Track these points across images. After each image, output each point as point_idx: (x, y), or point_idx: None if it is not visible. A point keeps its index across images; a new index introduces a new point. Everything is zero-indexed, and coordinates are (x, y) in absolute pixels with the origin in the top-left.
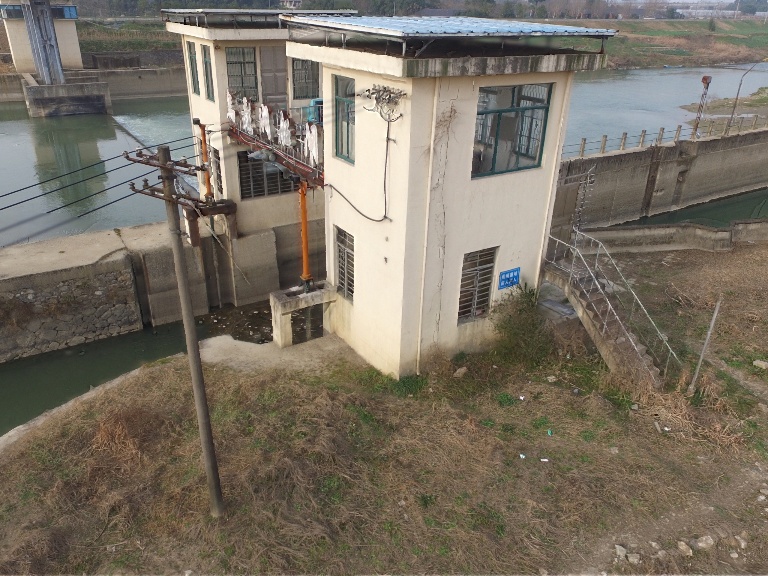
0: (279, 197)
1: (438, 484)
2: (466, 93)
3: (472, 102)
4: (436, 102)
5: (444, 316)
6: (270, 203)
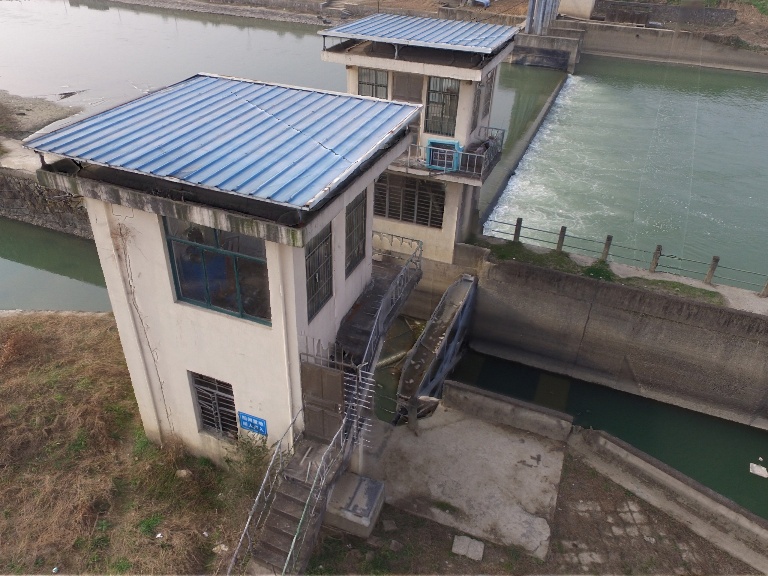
0: (397, 224)
1: None
2: (143, 215)
3: (153, 226)
4: (105, 214)
5: (180, 414)
6: (388, 226)
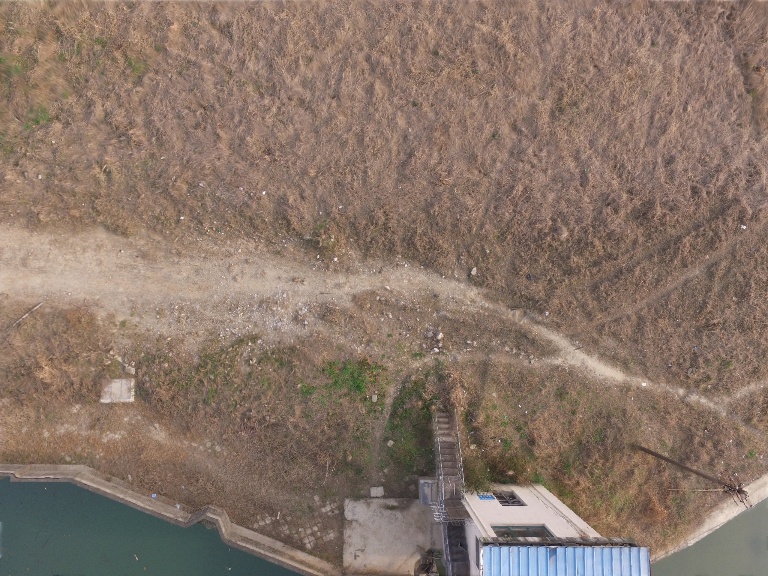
0: None
1: (564, 417)
2: None
3: None
4: None
5: None
6: None
